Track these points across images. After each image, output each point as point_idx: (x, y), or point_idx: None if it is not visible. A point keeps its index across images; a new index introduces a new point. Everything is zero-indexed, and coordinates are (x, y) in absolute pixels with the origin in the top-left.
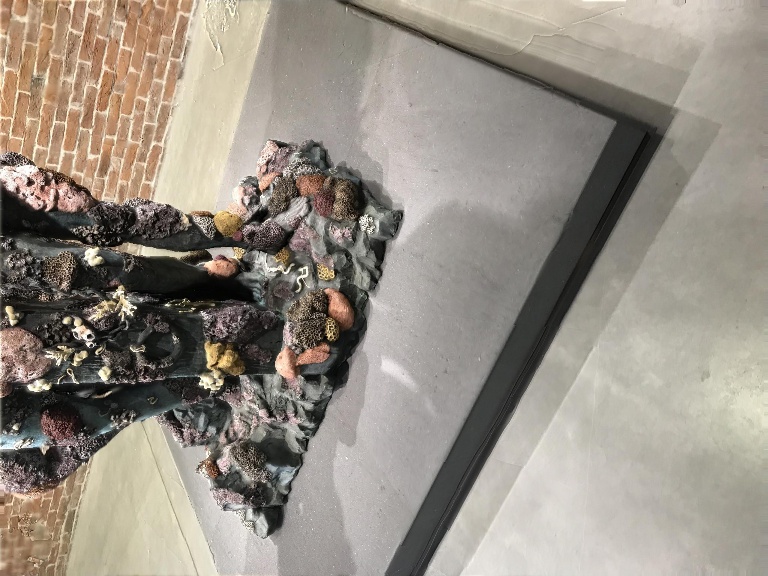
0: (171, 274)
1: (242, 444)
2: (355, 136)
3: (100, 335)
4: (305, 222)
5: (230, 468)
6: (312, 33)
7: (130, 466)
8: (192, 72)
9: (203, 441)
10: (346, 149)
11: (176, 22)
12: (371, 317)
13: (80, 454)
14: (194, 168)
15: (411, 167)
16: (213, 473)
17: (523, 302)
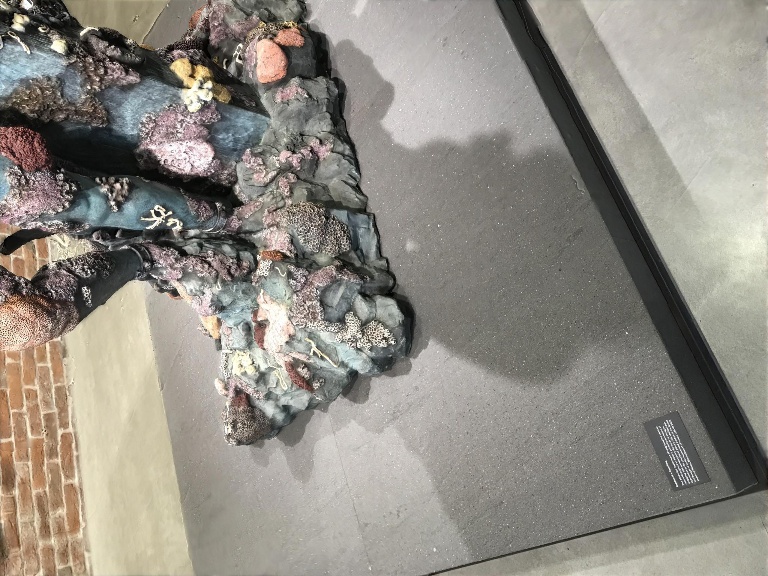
0: None
1: None
2: None
3: None
4: None
5: (292, 242)
6: None
7: None
8: (74, 332)
9: (244, 279)
10: None
11: None
12: (321, 23)
13: (73, 268)
14: (113, 384)
15: None
16: (274, 254)
17: None
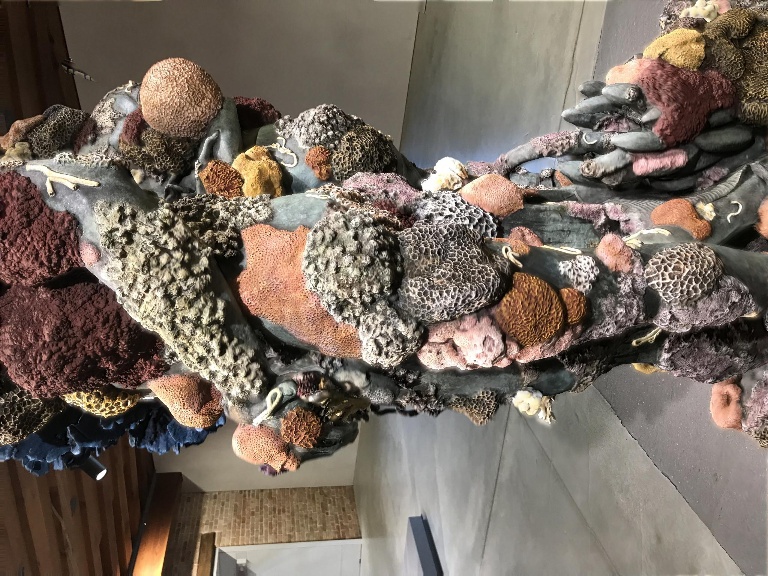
0: None
1: None
2: None
3: None
4: None
5: None
6: None
7: None
8: None
9: None
10: None
11: None
12: None
13: None
14: None
15: None
16: None
17: None
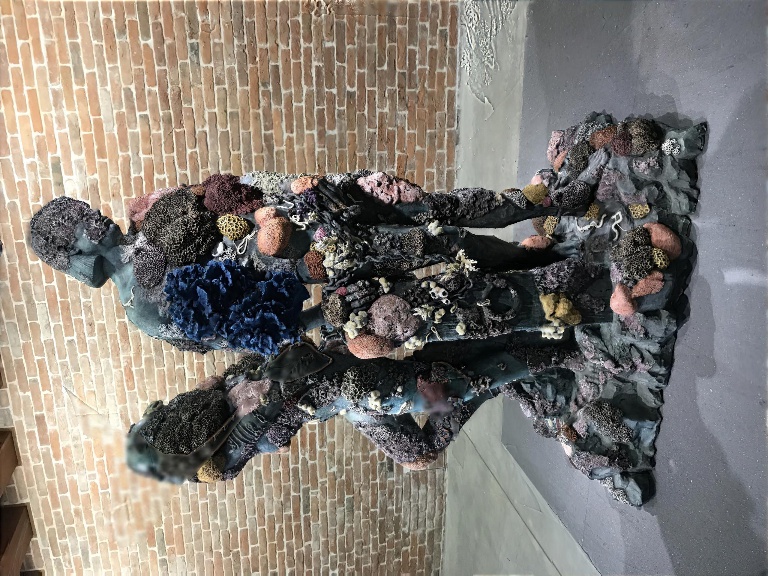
0: (496, 246)
1: (594, 402)
2: (636, 86)
3: (451, 294)
4: (607, 167)
5: (588, 429)
6: (571, 27)
7: (482, 511)
8: (467, 133)
9: (555, 413)
10: (630, 102)
11: (446, 97)
12: (699, 238)
13: None
14: None
15: (703, 79)
16: (572, 436)
17: None
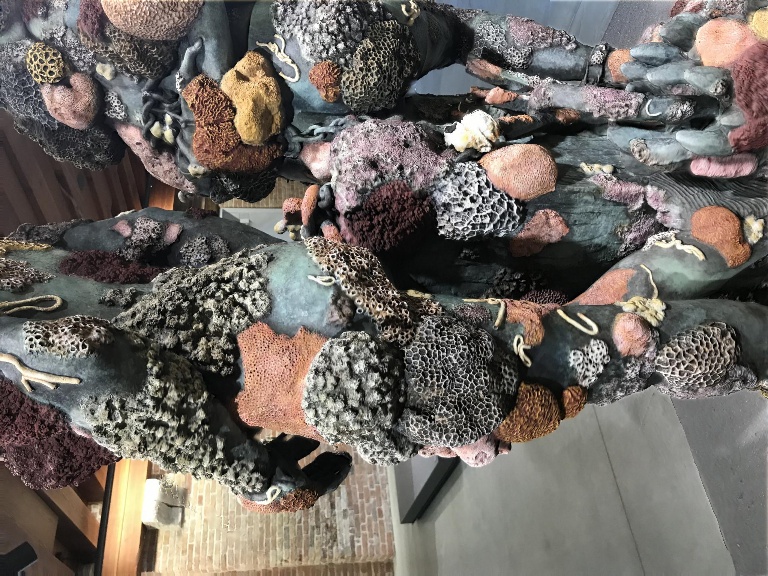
0: None
1: None
2: None
3: None
4: None
5: None
6: None
7: None
8: None
9: None
10: None
11: None
12: None
13: None
14: None
15: None
16: None
17: None
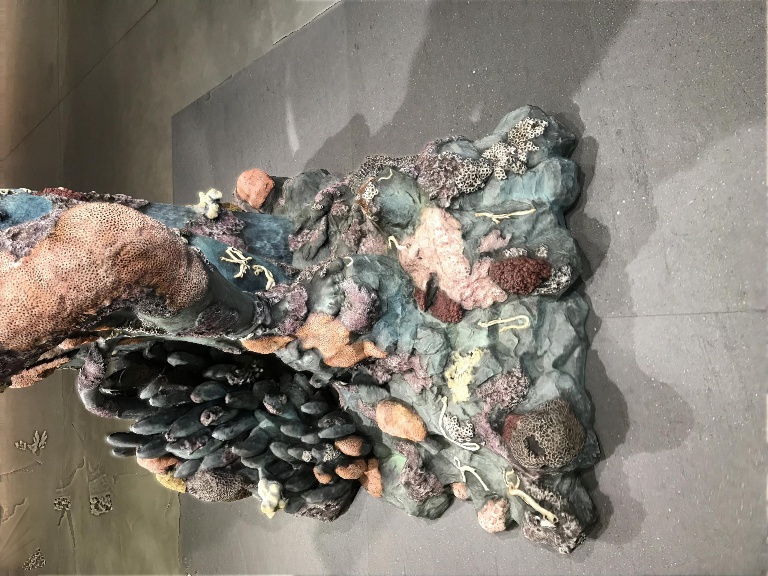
0: None
1: None
2: None
3: None
4: None
5: None
6: None
7: None
8: None
9: None
10: None
11: None
12: None
13: None
14: None
15: None
16: None
17: (224, 83)
